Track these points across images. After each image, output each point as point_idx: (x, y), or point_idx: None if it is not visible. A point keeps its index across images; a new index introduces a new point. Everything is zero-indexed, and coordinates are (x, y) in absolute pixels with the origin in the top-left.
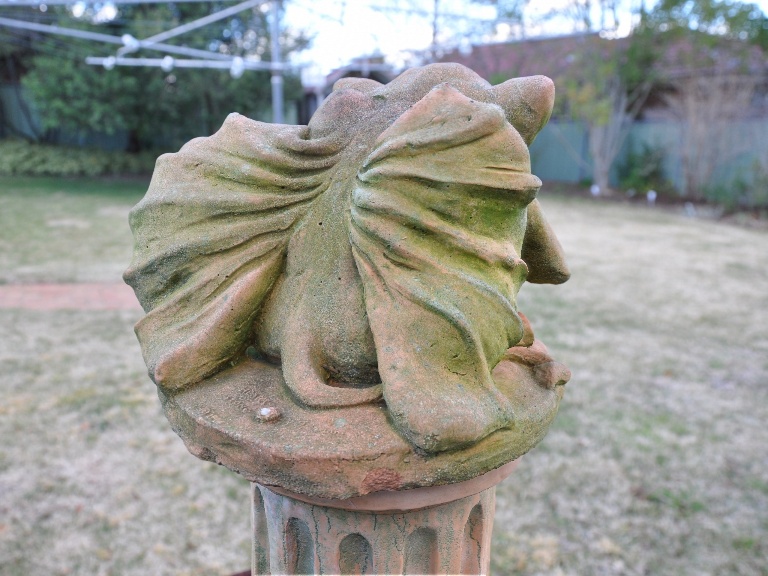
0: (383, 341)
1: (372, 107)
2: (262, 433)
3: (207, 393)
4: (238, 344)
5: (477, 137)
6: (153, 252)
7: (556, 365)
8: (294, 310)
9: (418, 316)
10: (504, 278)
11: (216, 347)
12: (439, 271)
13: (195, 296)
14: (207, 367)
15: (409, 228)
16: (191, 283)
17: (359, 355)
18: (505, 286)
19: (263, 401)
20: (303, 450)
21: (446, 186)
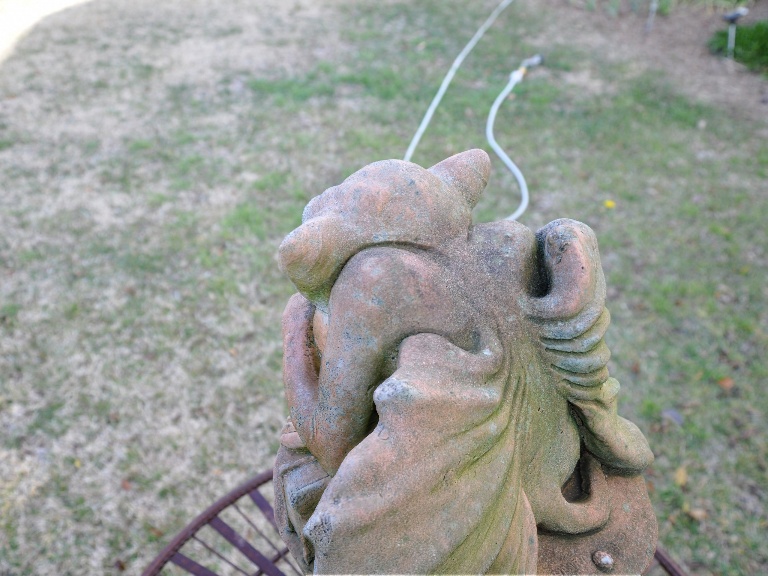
0: None
1: (440, 267)
2: (629, 570)
3: None
4: None
5: None
6: None
7: None
8: (539, 488)
9: None
10: None
11: None
12: None
13: None
14: None
15: None
16: (500, 572)
17: None
18: None
19: (582, 561)
20: (654, 544)
21: None
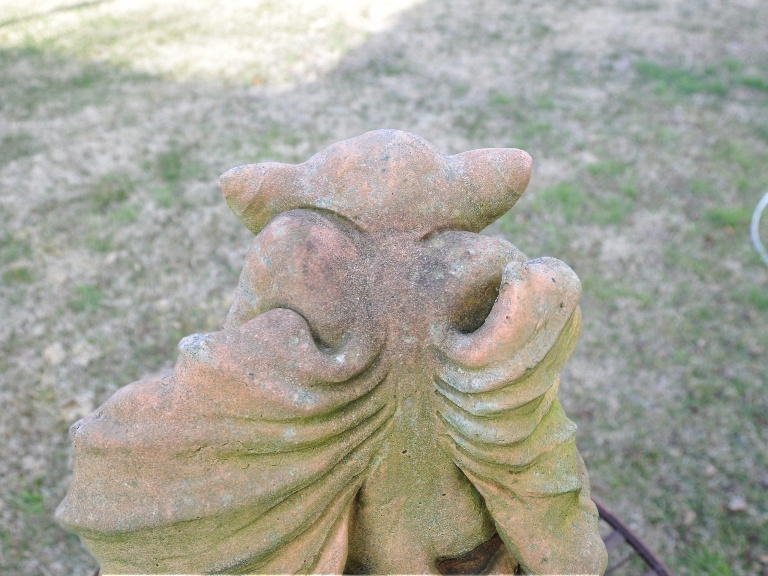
0: (526, 542)
1: (360, 254)
2: None
3: None
4: None
5: None
6: (179, 572)
7: None
8: (391, 537)
9: (549, 505)
10: None
11: None
12: (549, 452)
13: None
14: None
15: None
16: None
17: None
18: None
19: None
20: None
21: None
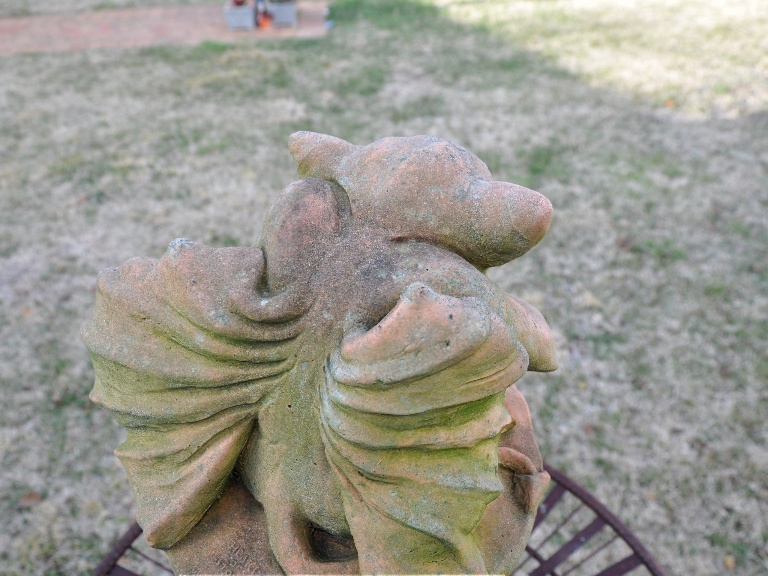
0: (363, 549)
1: (336, 231)
2: None
3: (199, 551)
4: (221, 489)
5: (456, 362)
6: (116, 402)
7: (535, 484)
8: (272, 475)
9: (396, 530)
10: (485, 450)
11: (200, 506)
12: (417, 483)
13: (170, 458)
14: (194, 521)
15: (384, 450)
16: (163, 443)
17: (341, 529)
18: (486, 458)
19: (253, 569)
20: None
21: (422, 413)
